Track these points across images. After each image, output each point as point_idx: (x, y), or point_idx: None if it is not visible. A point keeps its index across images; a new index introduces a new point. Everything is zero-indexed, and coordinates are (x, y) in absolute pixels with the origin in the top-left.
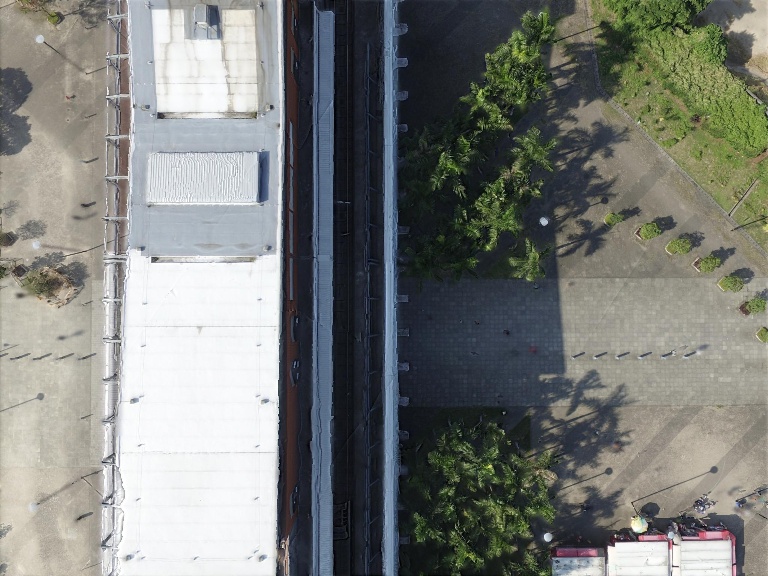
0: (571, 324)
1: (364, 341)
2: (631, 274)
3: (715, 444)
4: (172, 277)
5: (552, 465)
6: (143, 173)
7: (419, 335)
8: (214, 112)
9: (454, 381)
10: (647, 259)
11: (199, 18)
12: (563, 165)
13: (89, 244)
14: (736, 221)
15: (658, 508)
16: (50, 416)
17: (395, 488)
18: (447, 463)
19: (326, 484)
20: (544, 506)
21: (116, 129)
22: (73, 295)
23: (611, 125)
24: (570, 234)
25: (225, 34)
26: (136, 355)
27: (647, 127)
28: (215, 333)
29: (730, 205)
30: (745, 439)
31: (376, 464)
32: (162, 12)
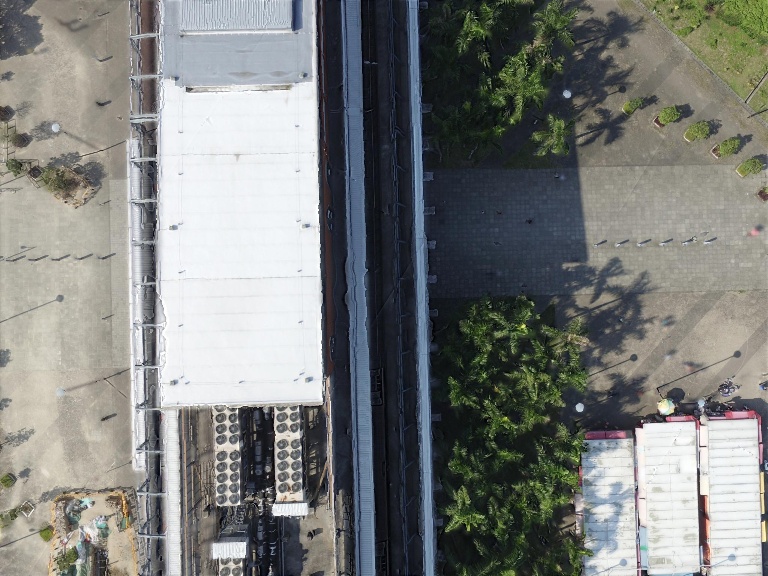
0: (592, 212)
1: (393, 208)
2: (650, 162)
3: (738, 329)
4: (208, 105)
5: (582, 334)
6: (175, 4)
7: (441, 226)
8: None
9: (478, 271)
10: (666, 147)
11: None
12: (580, 55)
13: (105, 143)
14: (752, 108)
15: (683, 393)
16: (70, 318)
17: (428, 352)
18: (478, 333)
19: (362, 337)
20: (576, 373)
21: None
22: (90, 195)
23: (627, 15)
24: (589, 123)
25: None
26: (173, 183)
27: (662, 16)
28: (253, 160)
29: (746, 92)
30: (767, 323)
31: (407, 336)
32: None
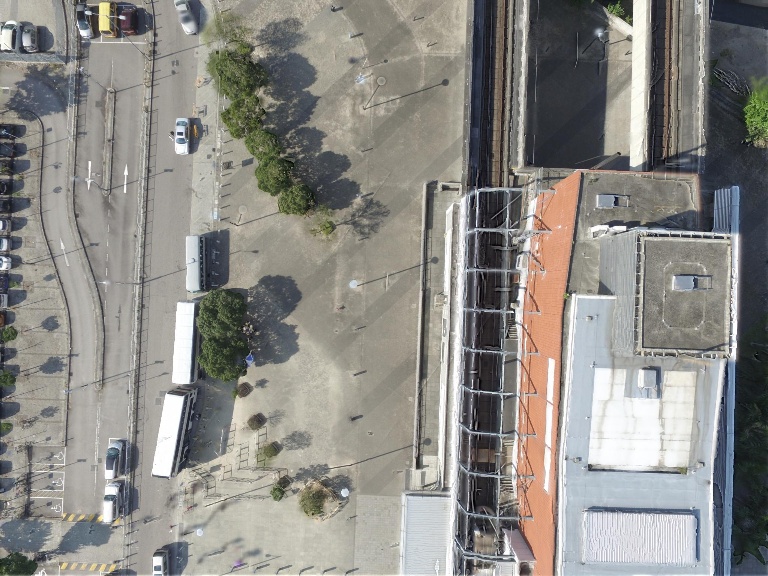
0: None
1: None
2: None
3: None
4: None
5: None
6: (576, 528)
7: None
8: (644, 465)
9: None
10: None
11: (648, 384)
12: None
13: (355, 458)
14: None
15: None
16: None
17: None
18: None
19: None
20: None
21: (460, 406)
22: (337, 509)
23: None
24: None
25: (664, 393)
26: None
27: None
28: None
29: None
30: None
31: None
32: (605, 371)
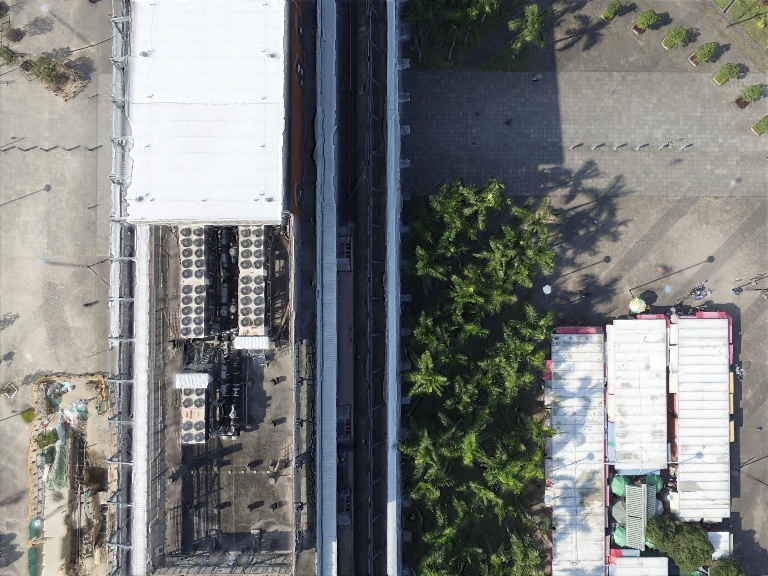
0: (569, 116)
1: (366, 82)
2: (628, 68)
3: (712, 234)
4: None
5: None
6: None
7: (420, 125)
8: None
9: (454, 171)
10: (644, 54)
11: None
12: None
13: (95, 39)
14: (731, 18)
15: (656, 296)
16: (57, 207)
17: (397, 220)
18: (448, 211)
19: (329, 192)
20: (543, 253)
21: None
22: (80, 89)
23: None
24: (568, 28)
25: None
26: (145, 13)
27: None
28: None
29: (725, 2)
30: (741, 230)
31: (378, 212)
32: None
